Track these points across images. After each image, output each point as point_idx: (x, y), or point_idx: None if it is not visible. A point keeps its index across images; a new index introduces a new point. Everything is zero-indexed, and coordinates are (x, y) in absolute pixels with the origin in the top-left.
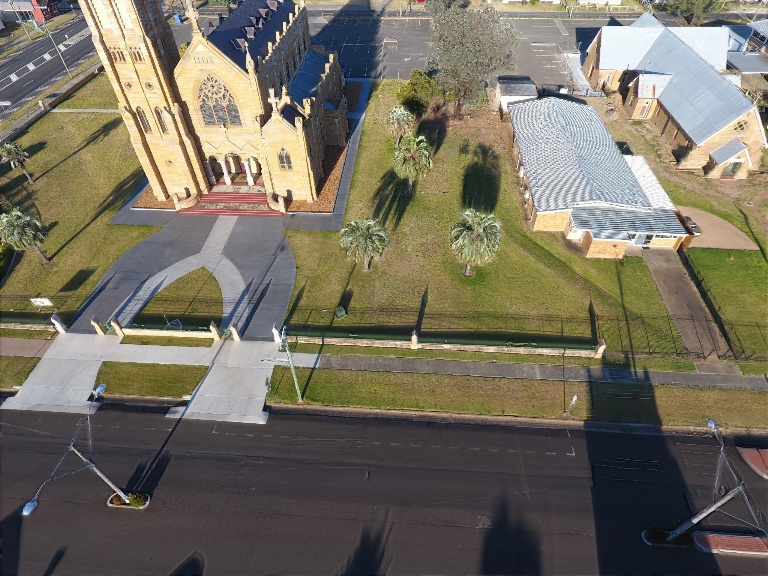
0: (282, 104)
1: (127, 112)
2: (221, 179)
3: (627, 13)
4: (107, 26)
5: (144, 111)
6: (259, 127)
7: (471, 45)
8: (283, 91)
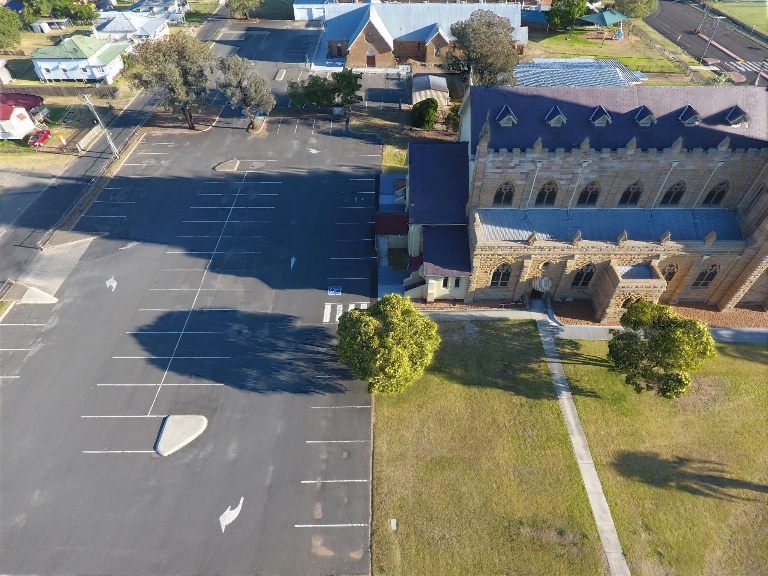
0: None
1: None
2: None
3: (198, 35)
4: None
5: None
6: None
7: None
8: None
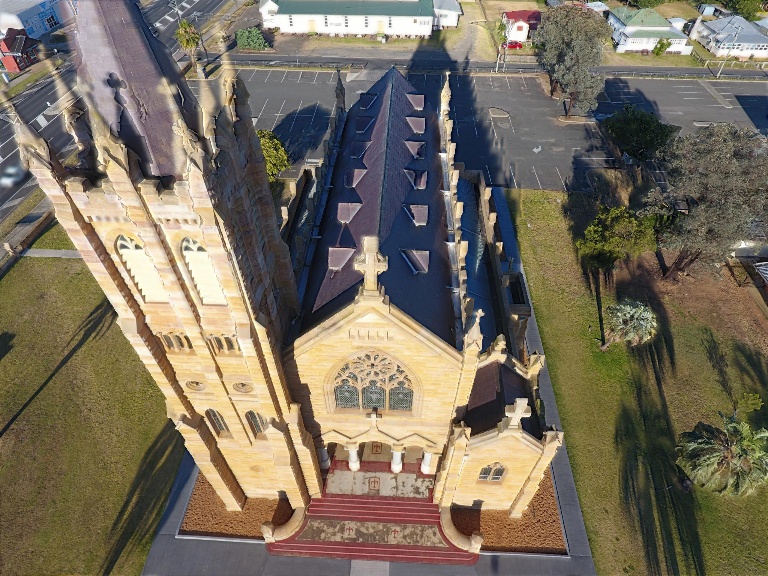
0: (487, 362)
1: (187, 426)
2: (337, 451)
3: None
4: (157, 296)
5: (222, 414)
6: (465, 442)
7: (759, 199)
8: (498, 346)
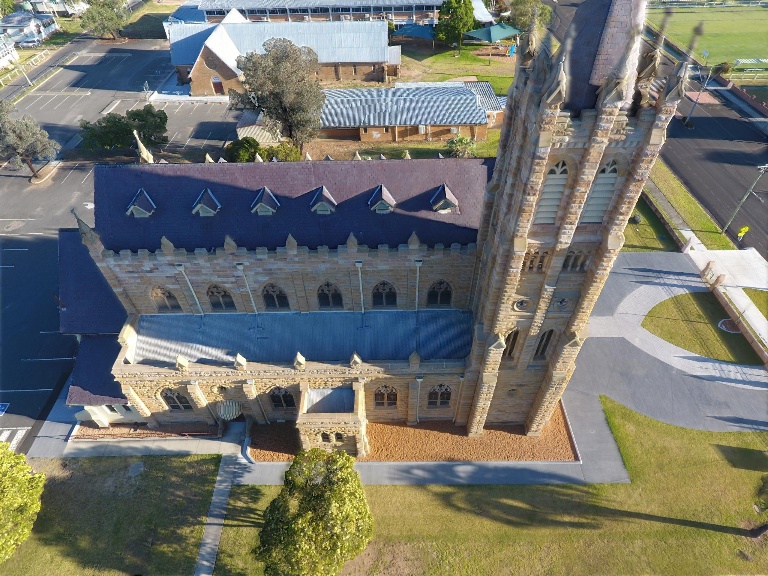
0: None
1: None
2: None
3: (50, 59)
4: None
5: None
6: None
7: None
8: None
